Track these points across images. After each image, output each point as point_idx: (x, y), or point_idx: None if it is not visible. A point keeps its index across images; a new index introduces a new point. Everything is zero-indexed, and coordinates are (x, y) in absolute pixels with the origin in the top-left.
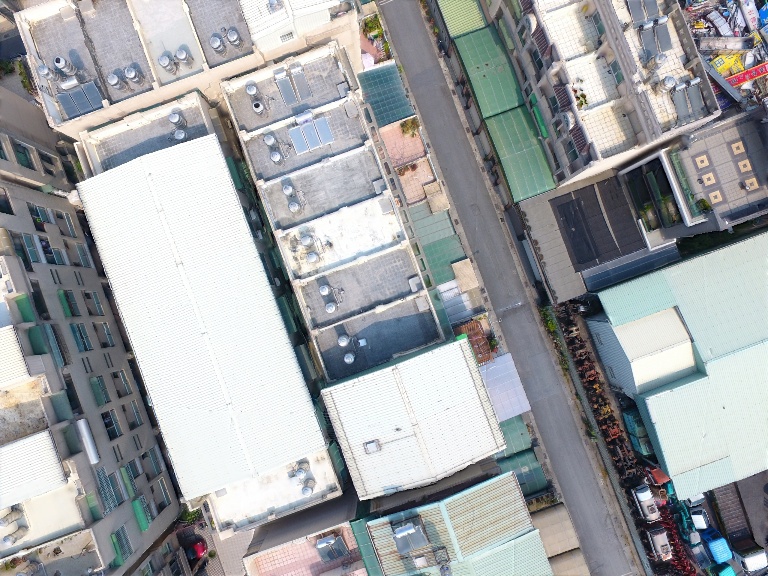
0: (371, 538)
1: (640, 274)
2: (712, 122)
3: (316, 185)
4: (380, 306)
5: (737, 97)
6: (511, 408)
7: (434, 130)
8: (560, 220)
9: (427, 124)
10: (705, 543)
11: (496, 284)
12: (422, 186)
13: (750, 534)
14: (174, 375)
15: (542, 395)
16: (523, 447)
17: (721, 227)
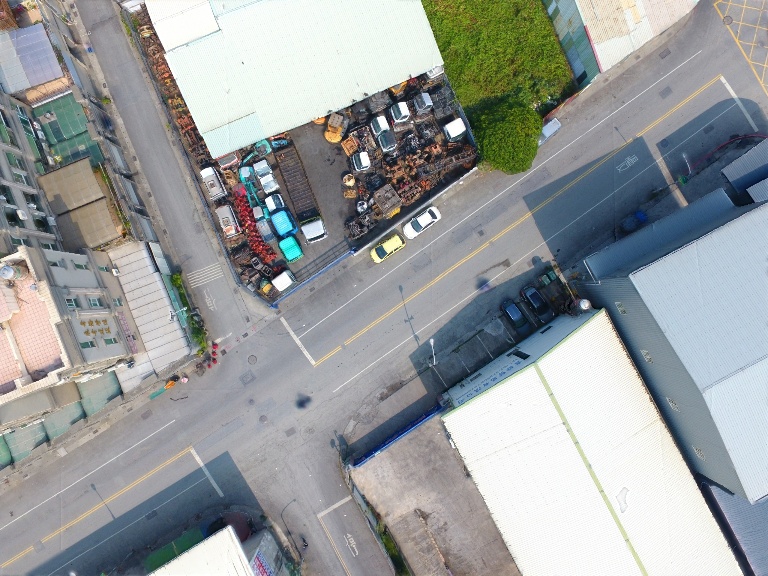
0: None
1: None
2: None
3: None
4: None
5: None
6: (43, 74)
7: None
8: None
9: None
10: (270, 219)
11: None
12: None
13: (318, 212)
14: None
15: (130, 101)
16: (80, 127)
17: None
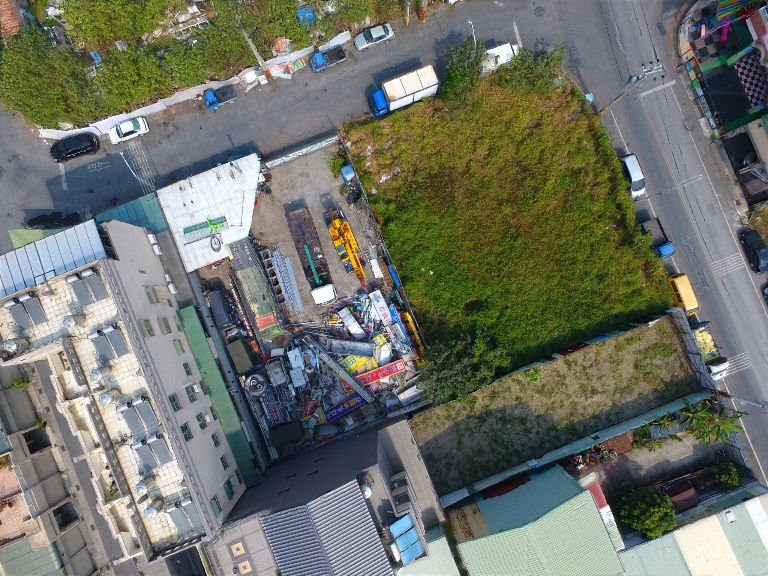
0: None
1: None
2: (232, 521)
3: None
4: None
5: (367, 398)
6: None
7: (69, 432)
8: None
9: (62, 426)
10: None
11: None
12: (23, 521)
13: None
14: None
15: None
16: None
17: None
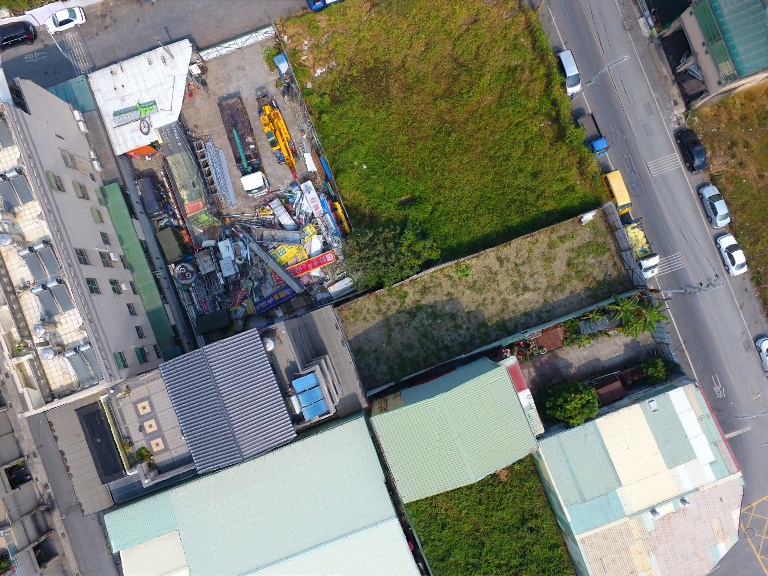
0: None
1: (167, 485)
2: (136, 375)
3: None
4: None
5: (296, 288)
6: None
7: None
8: (86, 430)
9: None
10: None
11: (60, 479)
12: None
13: None
14: None
15: None
16: None
17: (143, 484)
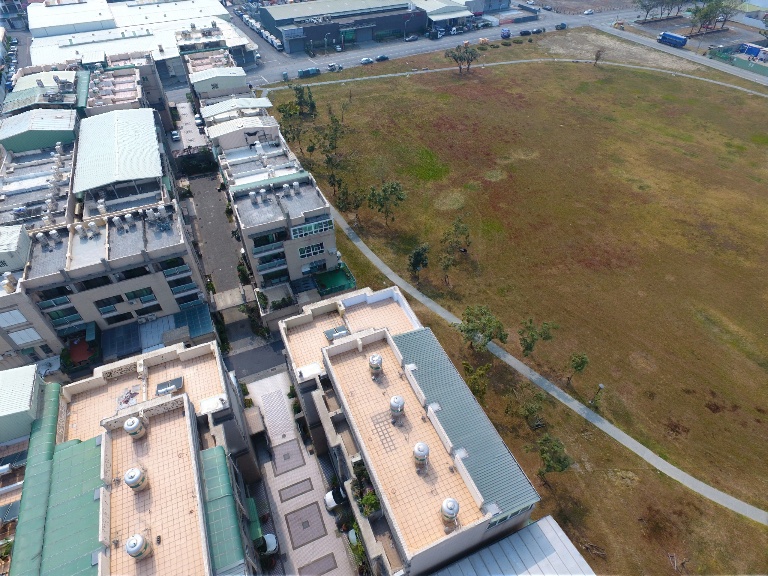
0: (75, 100)
1: None
2: None
3: (39, 198)
4: (34, 162)
5: None
6: None
7: None
8: None
9: None
10: None
11: None
12: None
13: None
14: (140, 130)
15: None
16: None
17: None
